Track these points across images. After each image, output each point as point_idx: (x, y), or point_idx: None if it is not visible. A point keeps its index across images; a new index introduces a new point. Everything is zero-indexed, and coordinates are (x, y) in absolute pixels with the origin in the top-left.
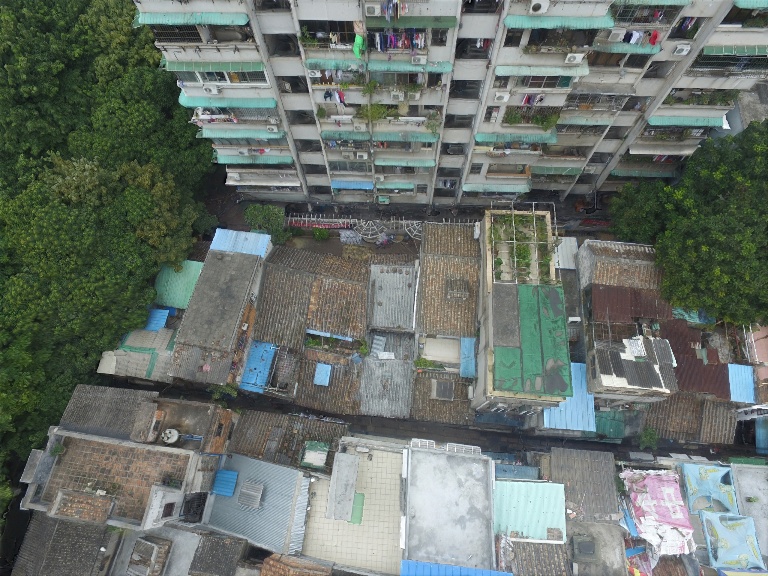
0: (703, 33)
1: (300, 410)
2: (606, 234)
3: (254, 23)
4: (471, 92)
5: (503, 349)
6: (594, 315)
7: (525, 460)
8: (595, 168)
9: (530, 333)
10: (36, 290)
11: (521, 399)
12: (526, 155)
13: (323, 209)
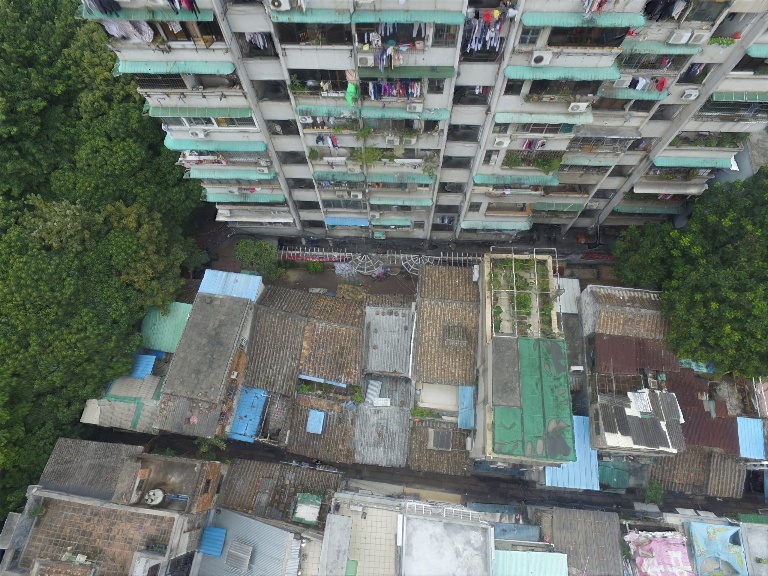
0: (712, 79)
1: (292, 457)
2: (608, 267)
3: (241, 71)
4: (470, 133)
5: (503, 409)
6: (598, 367)
7: (526, 514)
8: (598, 204)
9: (531, 391)
10: (14, 344)
11: (522, 459)
12: (527, 195)
13: (318, 240)
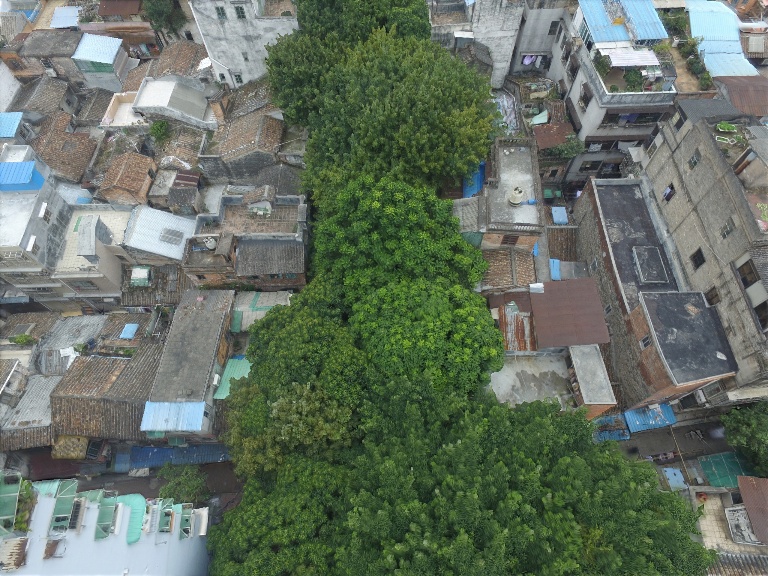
0: None
1: None
2: None
3: None
4: None
5: None
6: None
7: None
8: None
9: None
10: None
11: None
12: None
13: None
